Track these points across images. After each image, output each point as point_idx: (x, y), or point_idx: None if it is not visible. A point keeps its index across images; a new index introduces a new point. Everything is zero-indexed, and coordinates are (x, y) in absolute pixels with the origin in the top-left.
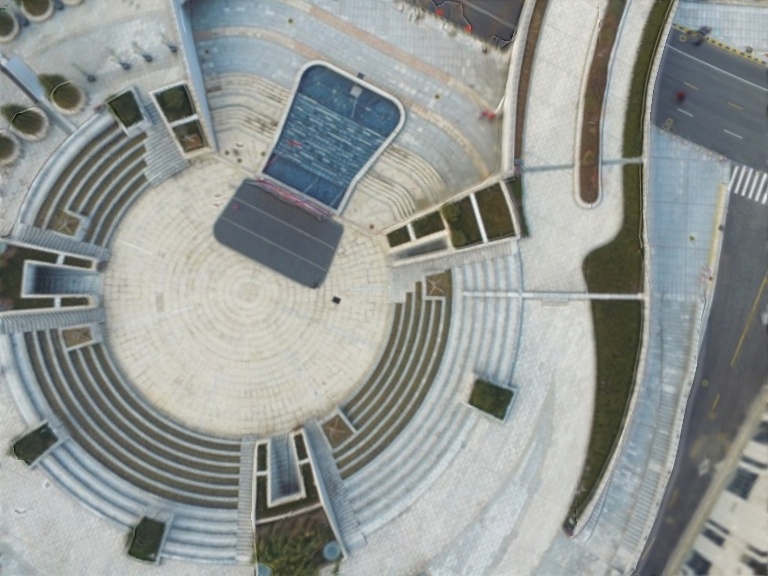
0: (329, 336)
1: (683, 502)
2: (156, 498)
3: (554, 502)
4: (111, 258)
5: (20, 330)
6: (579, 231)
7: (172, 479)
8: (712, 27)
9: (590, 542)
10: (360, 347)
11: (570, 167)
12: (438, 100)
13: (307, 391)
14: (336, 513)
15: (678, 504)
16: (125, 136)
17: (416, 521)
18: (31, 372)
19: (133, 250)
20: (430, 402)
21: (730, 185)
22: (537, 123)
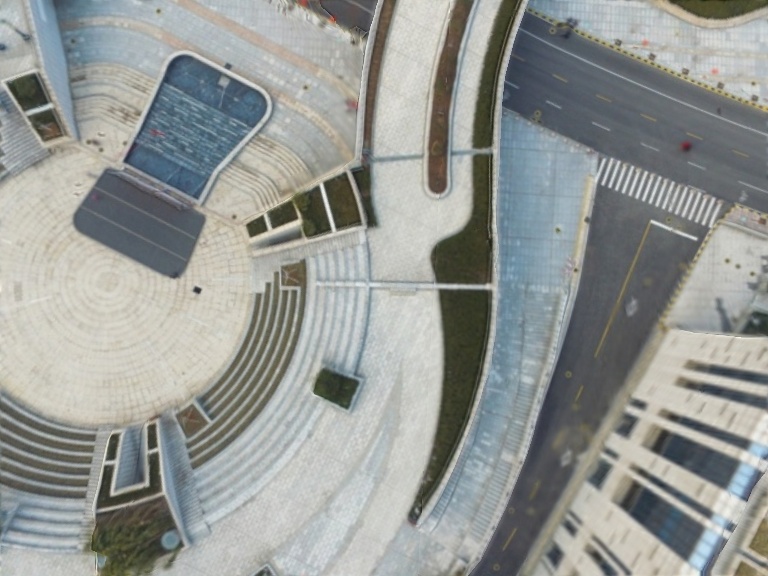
0: (189, 326)
1: (545, 493)
2: (2, 487)
3: (400, 492)
4: None
5: None
6: (428, 221)
7: (21, 468)
8: (581, 20)
9: (436, 532)
10: (220, 337)
11: (420, 157)
12: (306, 91)
13: (166, 381)
14: (180, 502)
15: (540, 495)
16: None
17: (261, 510)
18: None
19: None
20: (282, 392)
21: (597, 177)
22: (387, 113)
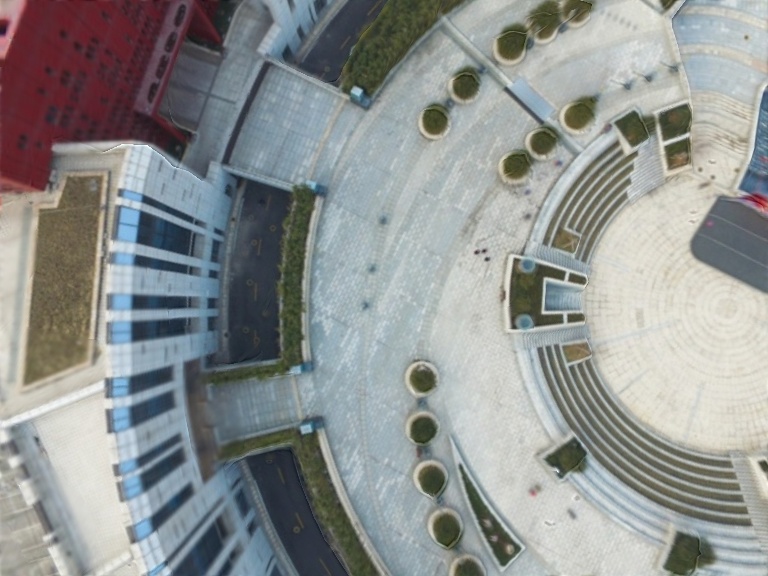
0: None
1: None
2: (674, 513)
3: None
4: (592, 274)
5: (534, 345)
6: None
7: (681, 494)
8: None
9: None
10: None
11: None
12: None
13: None
14: None
15: None
16: (621, 155)
17: None
18: (547, 387)
19: (612, 266)
20: None
21: None
22: None
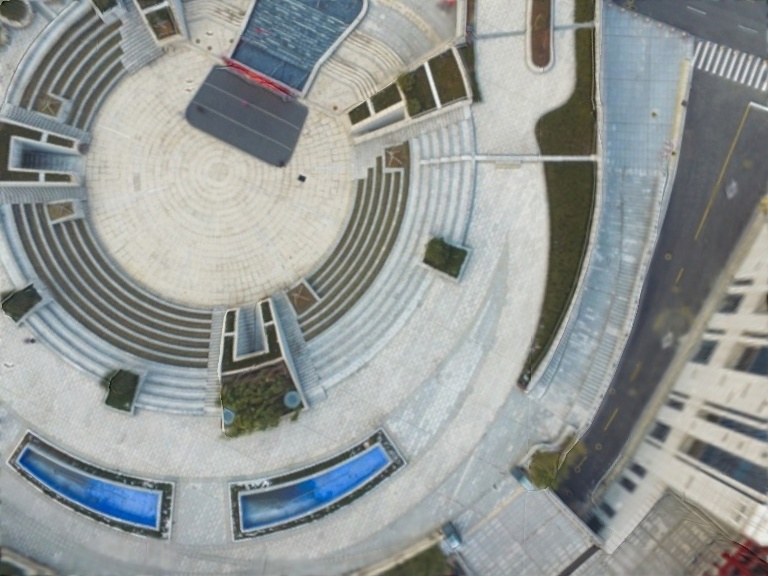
0: (295, 213)
1: (646, 374)
2: (132, 356)
3: (509, 359)
4: (92, 141)
5: (8, 202)
6: (531, 95)
7: (147, 341)
8: None
9: (545, 399)
10: (325, 223)
11: (522, 33)
12: None
13: (275, 265)
14: (298, 368)
15: (641, 376)
16: (102, 23)
17: (374, 376)
18: (18, 240)
19: (112, 134)
20: (389, 267)
21: (693, 61)
22: None
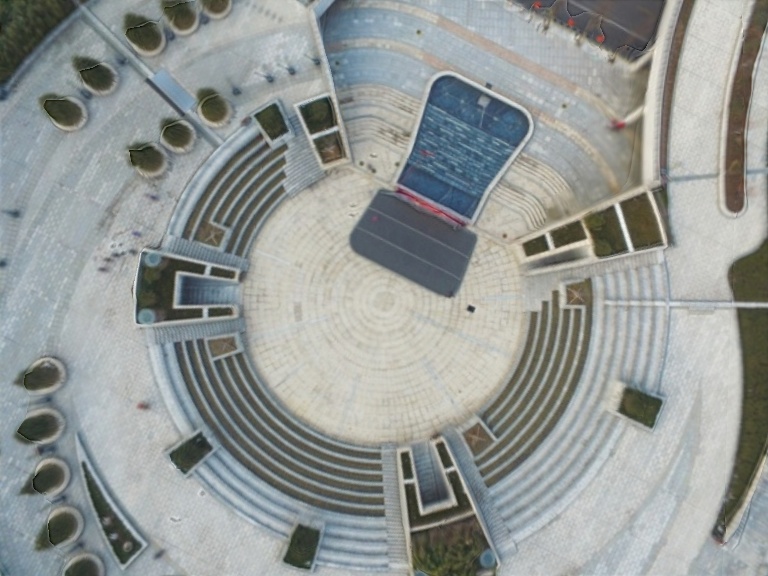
0: (464, 345)
1: None
2: (306, 506)
3: (702, 510)
4: (250, 268)
5: (170, 340)
6: (724, 240)
7: (319, 487)
8: None
9: (738, 549)
10: (495, 355)
11: (714, 176)
12: (565, 109)
13: (443, 399)
14: (487, 521)
15: None
16: (268, 148)
17: (566, 529)
18: (182, 382)
19: (271, 260)
20: (573, 410)
21: None
22: (681, 133)
